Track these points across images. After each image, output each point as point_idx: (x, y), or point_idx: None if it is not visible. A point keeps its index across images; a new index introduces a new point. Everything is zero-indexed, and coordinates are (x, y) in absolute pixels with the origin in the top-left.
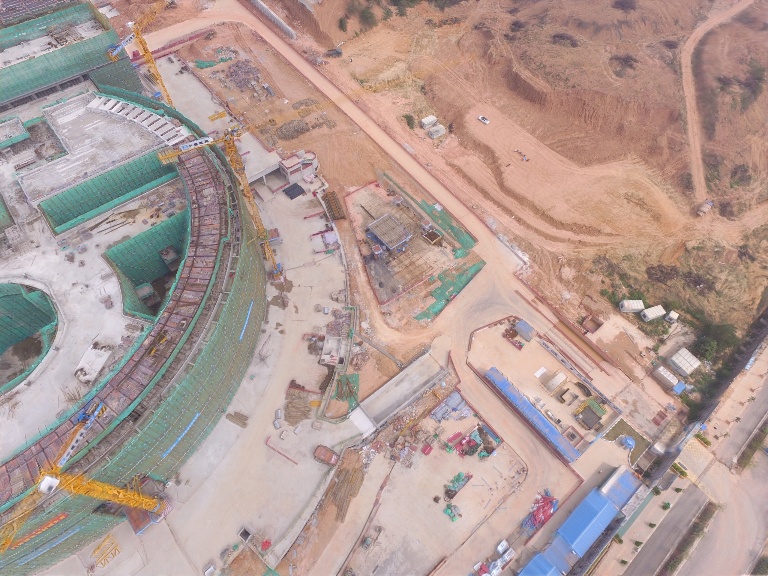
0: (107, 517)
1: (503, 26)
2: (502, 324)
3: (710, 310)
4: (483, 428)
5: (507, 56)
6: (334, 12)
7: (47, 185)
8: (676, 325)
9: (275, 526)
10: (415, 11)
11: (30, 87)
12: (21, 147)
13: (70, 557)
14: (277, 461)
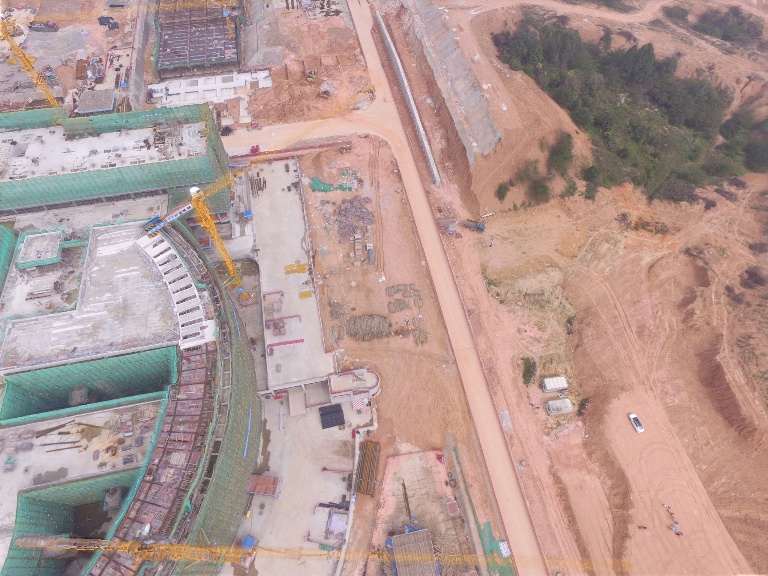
0: None
1: (730, 268)
2: None
3: None
4: None
5: (716, 327)
6: (497, 172)
7: (29, 348)
8: None
9: None
10: (609, 195)
11: (97, 193)
12: (49, 267)
13: None
14: None
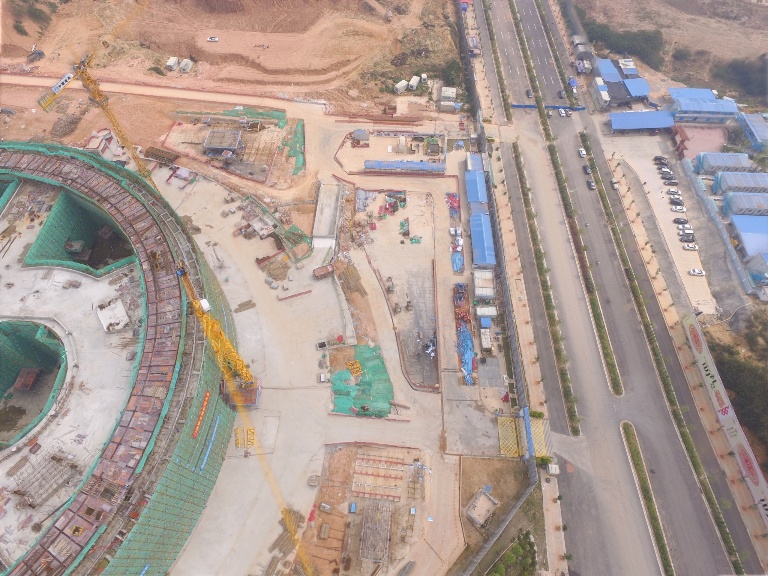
0: (227, 406)
1: None
2: (346, 142)
3: (437, 62)
4: (390, 194)
5: None
6: (1, 23)
7: None
8: (429, 82)
9: (334, 327)
10: None
11: None
12: None
13: (223, 464)
14: (297, 301)
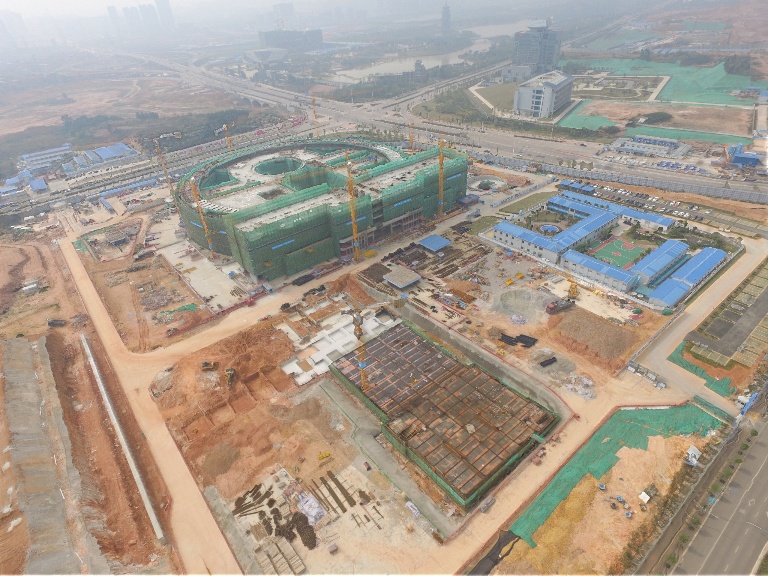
0: None
1: None
2: None
3: None
4: None
5: None
6: None
7: (265, 187)
8: None
9: None
10: None
11: None
12: None
13: None
14: None
